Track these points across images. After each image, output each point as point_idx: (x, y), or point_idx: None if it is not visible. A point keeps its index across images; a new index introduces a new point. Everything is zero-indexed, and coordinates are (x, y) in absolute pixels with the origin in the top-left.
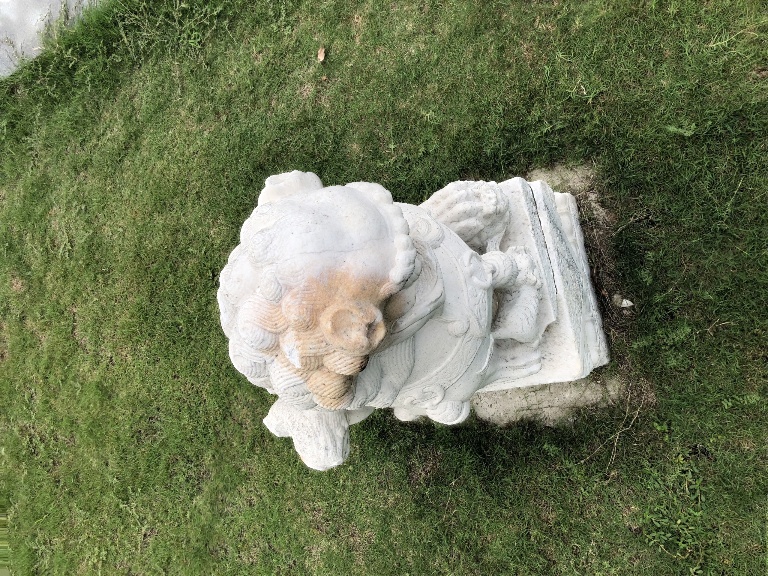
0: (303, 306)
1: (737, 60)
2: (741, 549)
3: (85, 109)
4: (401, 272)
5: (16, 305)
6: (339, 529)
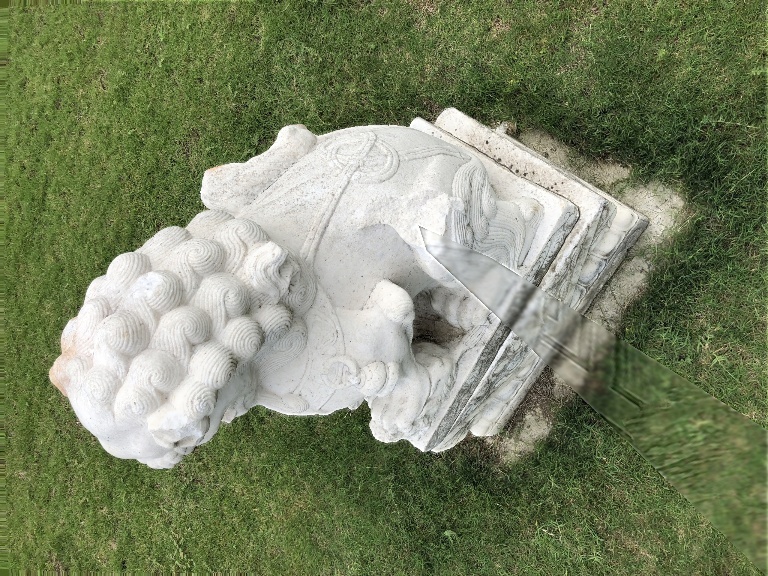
0: None
1: None
2: None
3: None
4: None
5: None
6: None
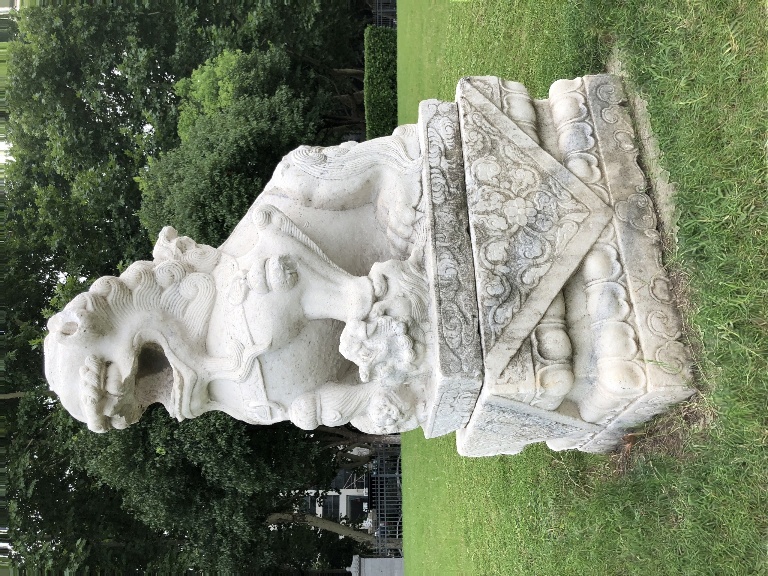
0: None
1: None
2: (544, 569)
3: None
4: None
5: None
6: None
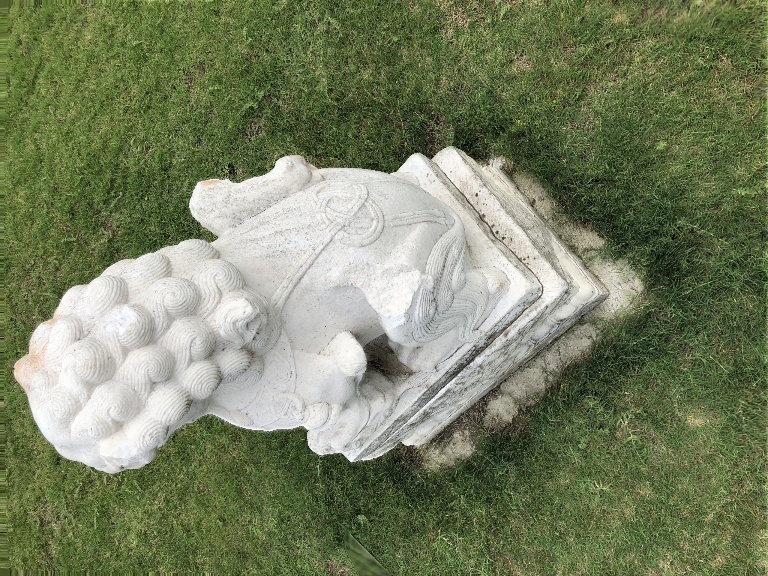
0: None
1: None
2: None
3: None
4: None
5: None
6: (479, 4)
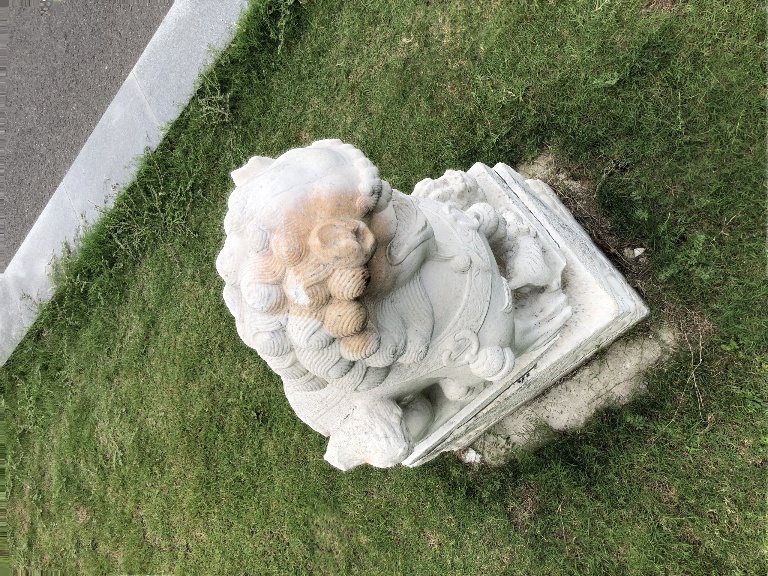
0: (289, 236)
1: (624, 8)
2: None
3: (103, 322)
4: (368, 183)
5: (86, 536)
6: None
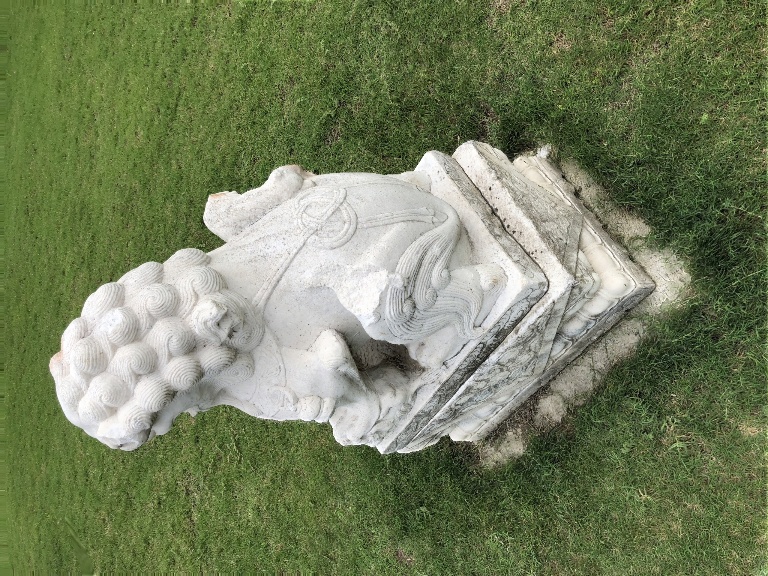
0: None
1: (421, 569)
2: None
3: None
4: None
5: None
6: None
